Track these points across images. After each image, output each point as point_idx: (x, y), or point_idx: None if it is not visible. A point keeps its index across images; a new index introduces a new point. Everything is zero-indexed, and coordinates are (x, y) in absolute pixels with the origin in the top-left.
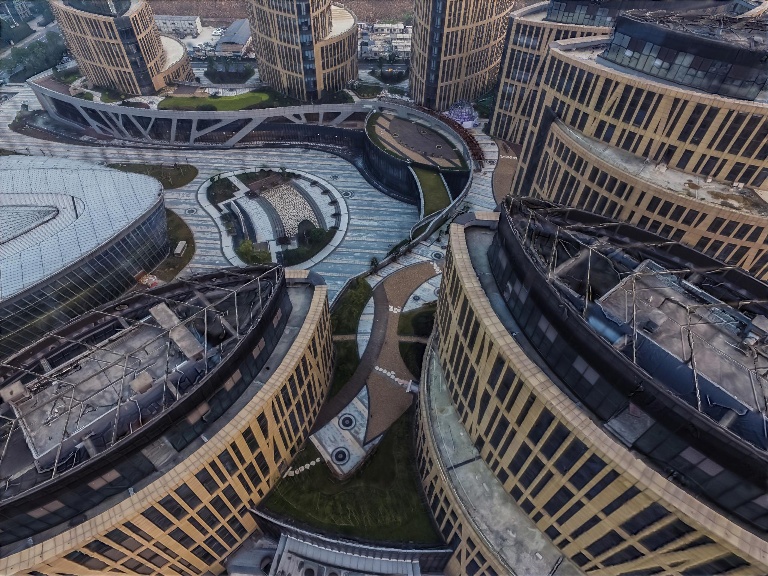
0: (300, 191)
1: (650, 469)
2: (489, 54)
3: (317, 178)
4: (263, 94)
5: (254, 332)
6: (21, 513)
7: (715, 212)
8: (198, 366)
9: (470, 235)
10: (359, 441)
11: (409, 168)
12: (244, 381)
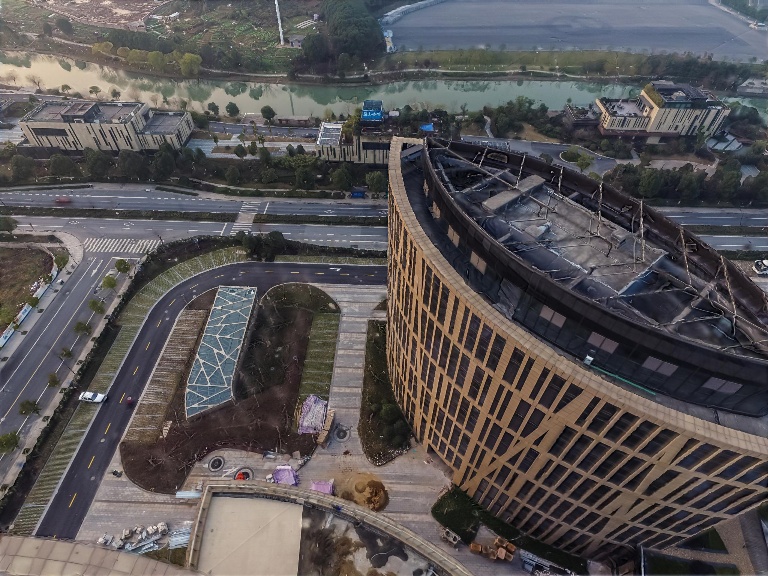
0: None
1: None
2: None
3: None
4: None
5: None
6: None
7: None
8: None
9: None
10: None
11: None
12: None
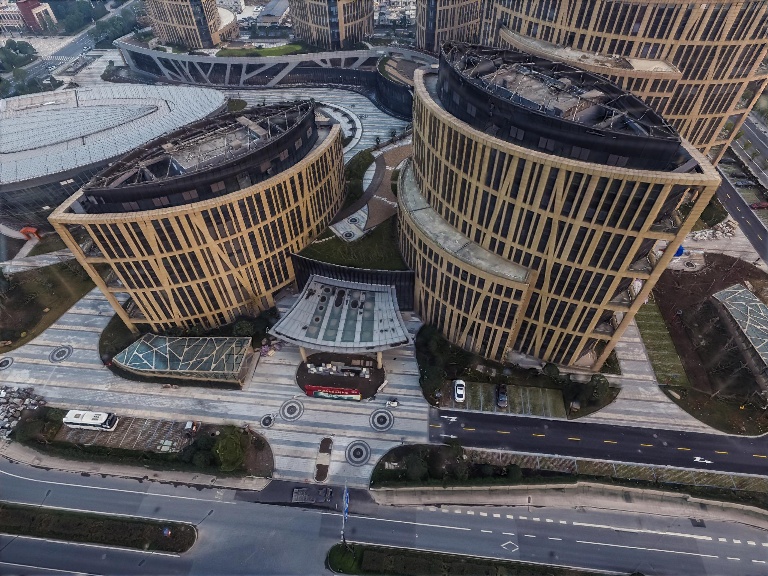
0: (325, 115)
1: (491, 136)
2: (478, 7)
3: (339, 106)
4: (297, 46)
5: (296, 129)
6: (179, 192)
7: (593, 69)
8: (265, 142)
9: (428, 78)
10: (361, 229)
11: (409, 91)
12: (290, 162)
